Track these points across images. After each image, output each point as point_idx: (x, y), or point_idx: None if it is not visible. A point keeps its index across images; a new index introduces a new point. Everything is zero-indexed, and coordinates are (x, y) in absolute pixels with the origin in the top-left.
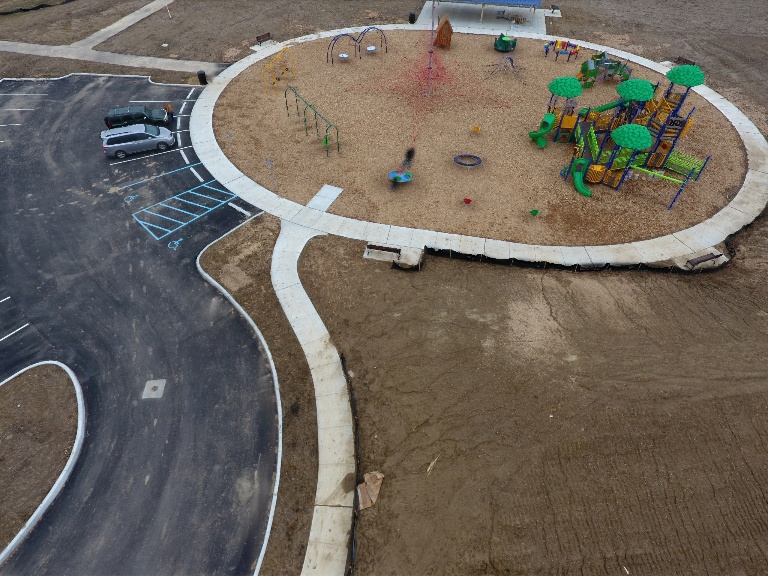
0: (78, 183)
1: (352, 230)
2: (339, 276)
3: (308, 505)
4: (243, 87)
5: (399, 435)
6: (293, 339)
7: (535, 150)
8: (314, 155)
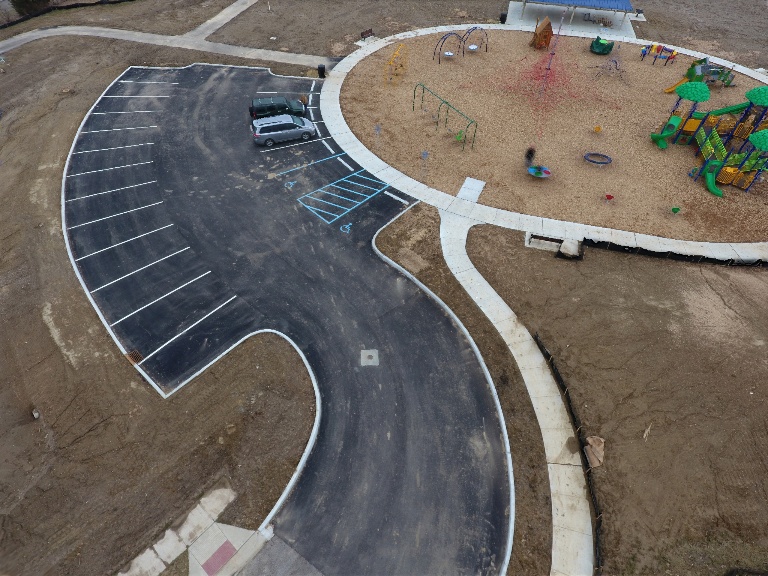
0: (236, 168)
1: (507, 221)
2: (509, 262)
3: (541, 463)
4: (361, 81)
5: (608, 406)
6: (484, 318)
7: (657, 151)
8: (449, 149)
